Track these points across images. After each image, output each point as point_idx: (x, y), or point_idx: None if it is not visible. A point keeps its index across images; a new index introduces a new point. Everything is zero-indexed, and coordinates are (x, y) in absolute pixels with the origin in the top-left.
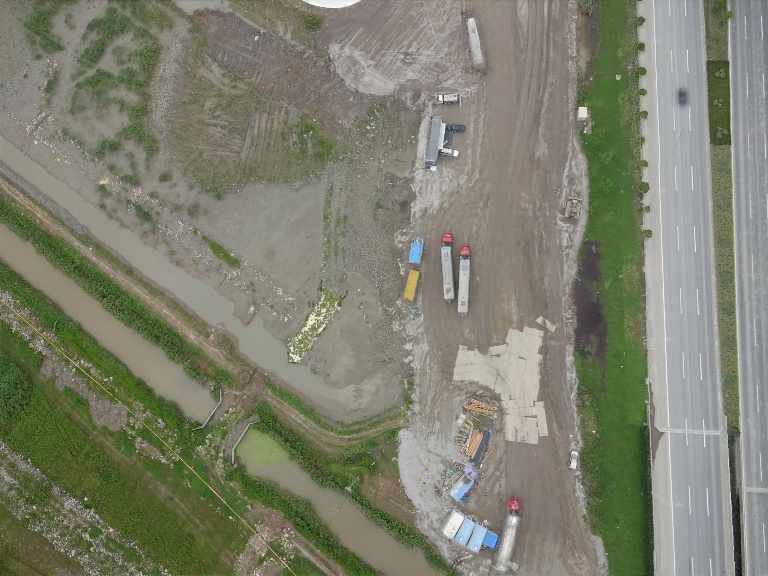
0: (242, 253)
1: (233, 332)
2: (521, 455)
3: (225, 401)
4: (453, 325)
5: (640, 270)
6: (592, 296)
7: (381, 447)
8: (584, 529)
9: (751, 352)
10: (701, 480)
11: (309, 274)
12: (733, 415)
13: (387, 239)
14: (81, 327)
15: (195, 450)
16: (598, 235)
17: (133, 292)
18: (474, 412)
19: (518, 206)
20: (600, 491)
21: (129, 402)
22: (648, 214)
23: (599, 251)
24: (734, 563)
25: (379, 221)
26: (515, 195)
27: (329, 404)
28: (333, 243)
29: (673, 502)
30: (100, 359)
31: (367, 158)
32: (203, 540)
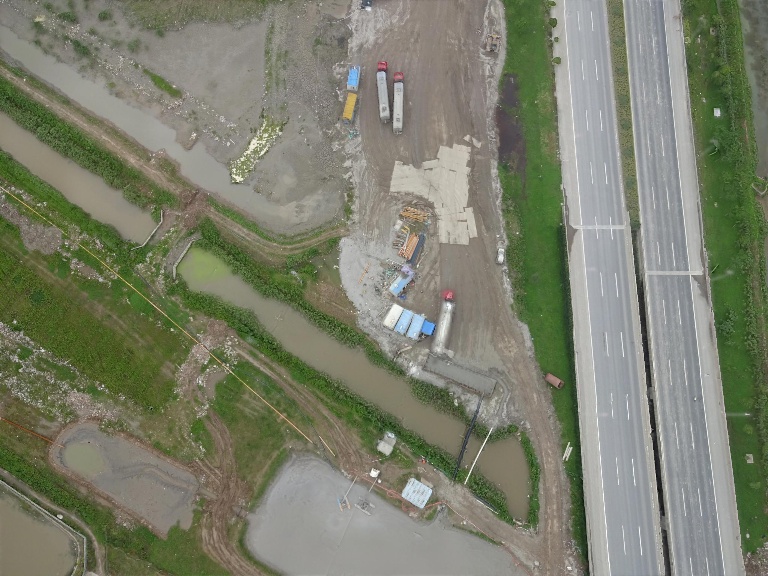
0: (184, 85)
1: (175, 157)
2: (454, 255)
3: (166, 221)
4: (389, 144)
5: (552, 95)
6: (512, 119)
7: (323, 256)
8: (512, 316)
9: (646, 160)
10: (610, 267)
11: (251, 103)
12: (634, 211)
13: (326, 71)
14: (12, 157)
15: (135, 268)
16: (515, 68)
17: (70, 120)
18: (410, 219)
19: (445, 42)
20: (525, 284)
21: (64, 225)
22: (557, 49)
23: (517, 82)
24: (641, 334)
25: (318, 56)
26: (442, 33)
27: (272, 220)
28: (274, 75)
29: (588, 287)
30: (33, 184)
31: (306, 1)
32: (143, 354)
